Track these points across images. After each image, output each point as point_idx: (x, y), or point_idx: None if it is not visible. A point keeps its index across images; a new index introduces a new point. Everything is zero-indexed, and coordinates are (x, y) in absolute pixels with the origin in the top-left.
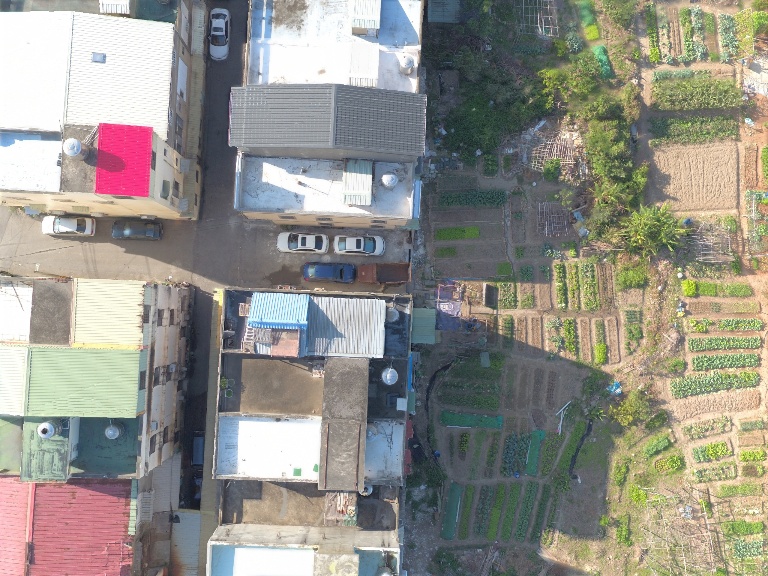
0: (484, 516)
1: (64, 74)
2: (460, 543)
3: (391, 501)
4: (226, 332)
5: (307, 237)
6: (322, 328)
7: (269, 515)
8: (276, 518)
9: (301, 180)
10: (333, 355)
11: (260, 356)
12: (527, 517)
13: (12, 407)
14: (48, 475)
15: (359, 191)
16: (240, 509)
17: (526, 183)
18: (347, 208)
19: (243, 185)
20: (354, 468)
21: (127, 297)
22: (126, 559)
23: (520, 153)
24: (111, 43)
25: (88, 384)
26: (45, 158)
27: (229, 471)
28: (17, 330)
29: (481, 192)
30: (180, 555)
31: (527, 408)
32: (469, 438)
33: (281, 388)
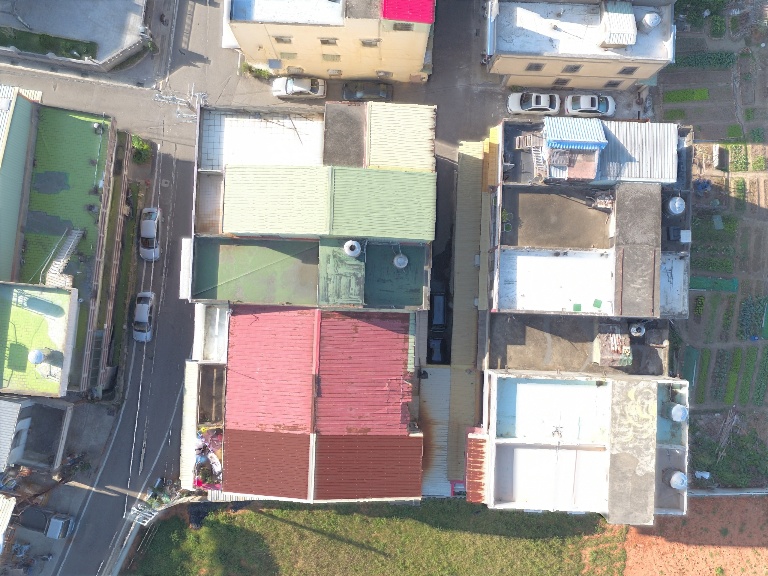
0: (721, 379)
1: None
2: (697, 407)
3: (658, 345)
4: (505, 164)
5: (541, 96)
6: (614, 152)
7: (533, 361)
8: (541, 364)
9: (556, 24)
10: (626, 180)
11: (537, 191)
12: (765, 381)
13: (315, 226)
14: (345, 299)
15: (624, 29)
16: (504, 355)
17: (754, 44)
18: (603, 53)
19: (498, 30)
20: (650, 294)
21: (419, 121)
22: (406, 396)
23: (754, 10)
24: None
25: (390, 204)
26: None
27: (508, 307)
28: (296, 163)
29: (710, 53)
30: (429, 411)
31: (762, 271)
32: (704, 301)
33: (559, 223)
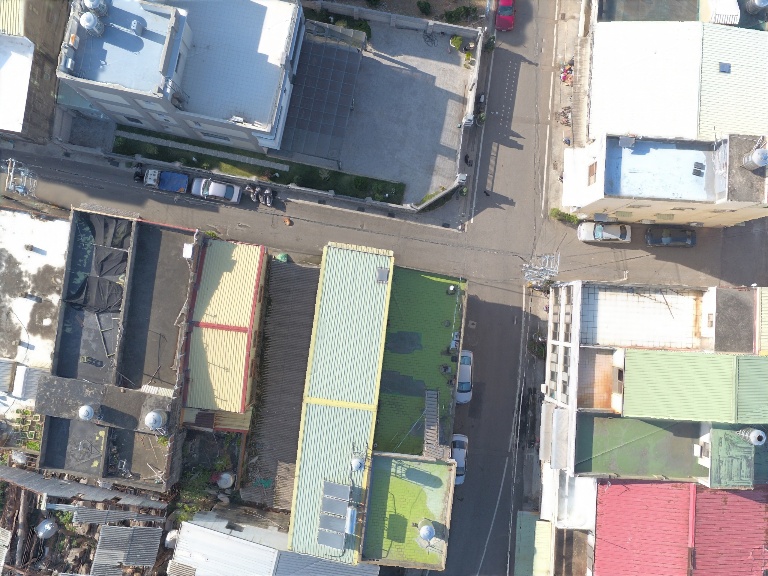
0: None
1: (697, 84)
2: None
3: None
4: None
5: None
6: None
7: None
8: None
9: None
10: None
11: None
12: None
13: (719, 414)
14: (737, 481)
15: None
16: None
17: None
18: None
19: None
20: None
21: None
22: (766, 564)
23: None
24: (736, 53)
25: None
26: (680, 167)
27: None
28: (668, 337)
29: None
30: None
31: None
32: None
33: None
